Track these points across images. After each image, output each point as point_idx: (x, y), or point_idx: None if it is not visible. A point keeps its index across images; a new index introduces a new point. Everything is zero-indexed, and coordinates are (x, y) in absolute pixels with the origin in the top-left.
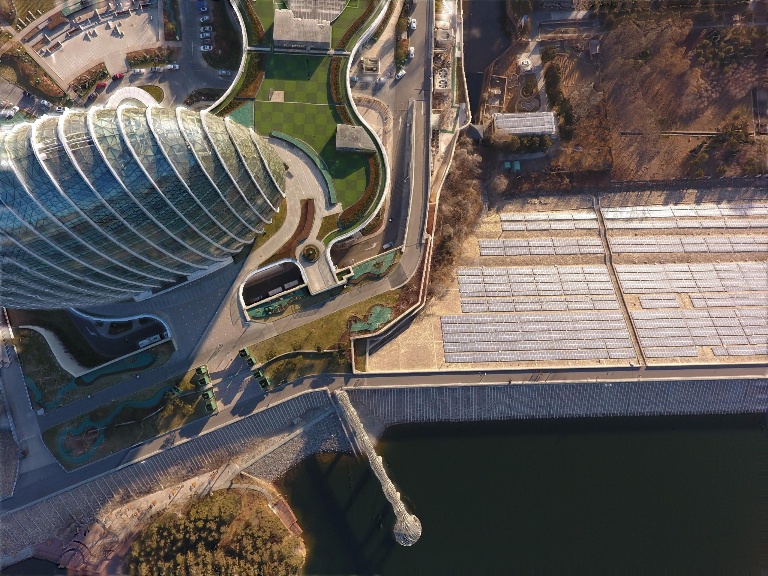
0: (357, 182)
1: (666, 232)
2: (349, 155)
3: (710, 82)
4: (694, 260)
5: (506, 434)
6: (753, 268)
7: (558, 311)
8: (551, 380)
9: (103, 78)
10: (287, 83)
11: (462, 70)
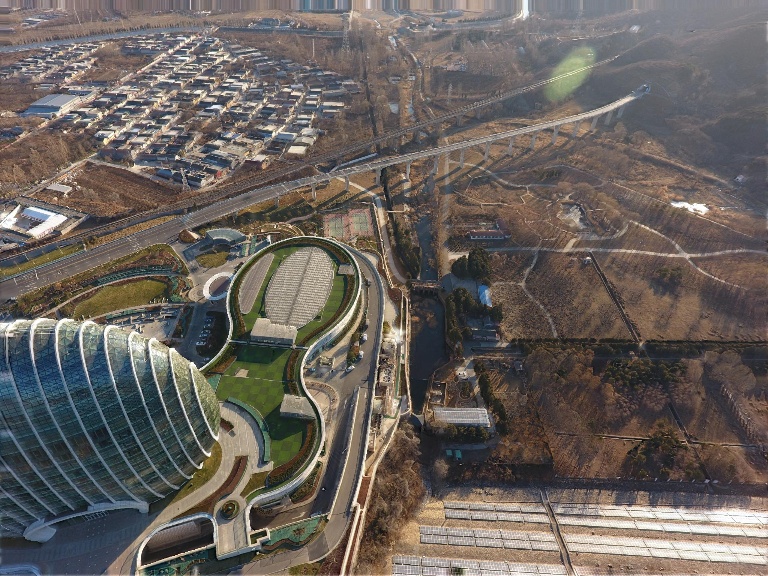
0: (293, 444)
1: (626, 533)
2: (291, 420)
3: (626, 396)
4: (667, 568)
5: None
6: None
7: None
8: None
9: None
10: (253, 365)
11: (405, 372)
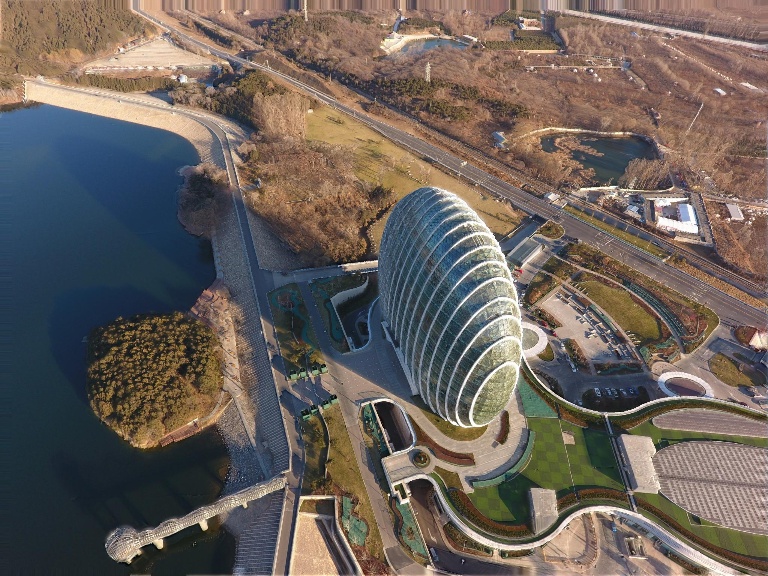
0: (498, 511)
1: None
2: (526, 504)
3: None
4: None
5: None
6: None
7: None
8: None
9: (550, 325)
10: (584, 447)
11: None
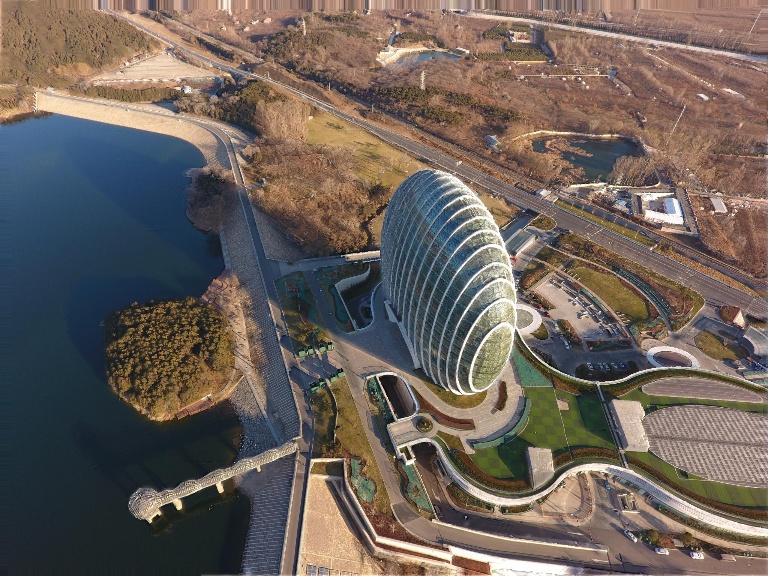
0: (498, 469)
1: None
2: (524, 463)
3: None
4: None
5: None
6: None
7: None
8: None
9: (544, 308)
10: (578, 413)
11: None
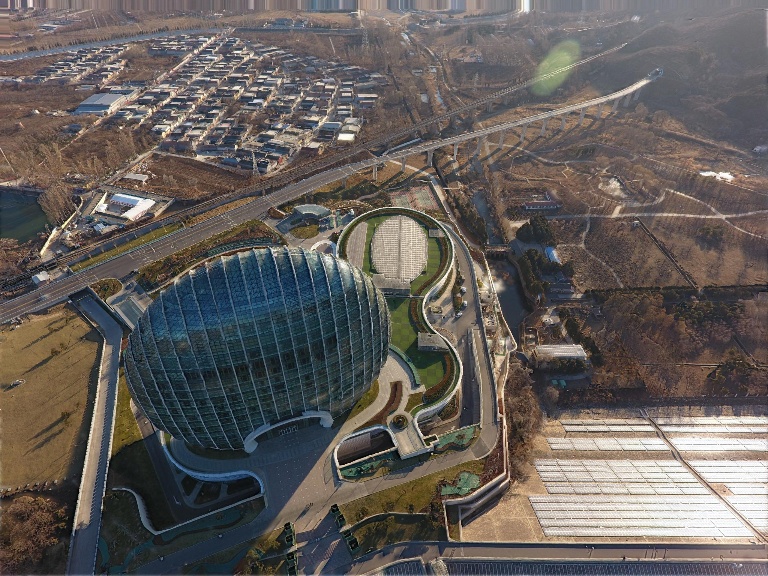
0: (436, 371)
1: (721, 436)
2: (428, 353)
3: (696, 332)
4: (763, 458)
5: None
6: None
7: (647, 495)
8: (670, 557)
9: None
10: None
11: (503, 318)
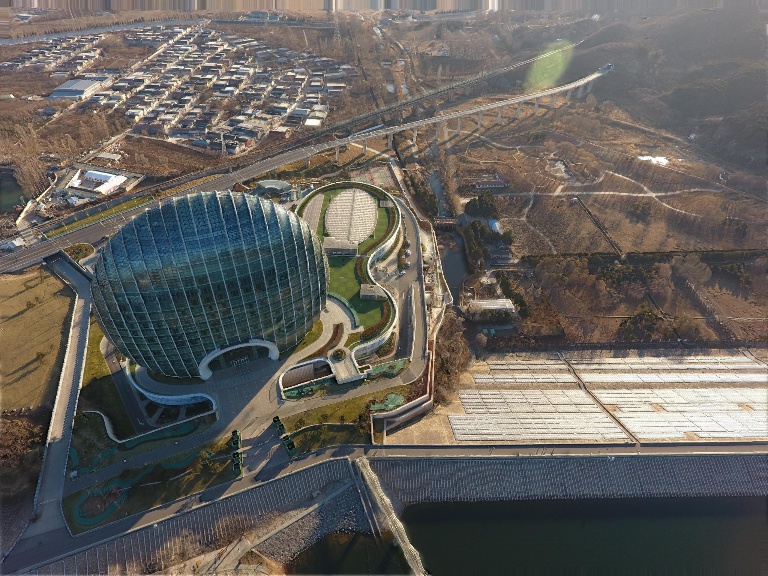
0: (375, 315)
1: (623, 372)
2: (369, 301)
3: (615, 290)
4: (654, 387)
5: (528, 516)
6: (706, 392)
7: (549, 413)
8: (556, 454)
9: None
10: None
11: (443, 278)
